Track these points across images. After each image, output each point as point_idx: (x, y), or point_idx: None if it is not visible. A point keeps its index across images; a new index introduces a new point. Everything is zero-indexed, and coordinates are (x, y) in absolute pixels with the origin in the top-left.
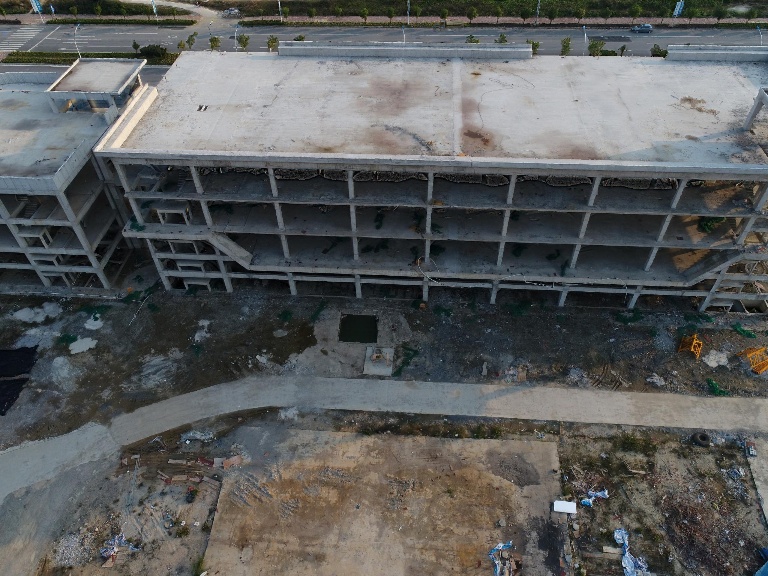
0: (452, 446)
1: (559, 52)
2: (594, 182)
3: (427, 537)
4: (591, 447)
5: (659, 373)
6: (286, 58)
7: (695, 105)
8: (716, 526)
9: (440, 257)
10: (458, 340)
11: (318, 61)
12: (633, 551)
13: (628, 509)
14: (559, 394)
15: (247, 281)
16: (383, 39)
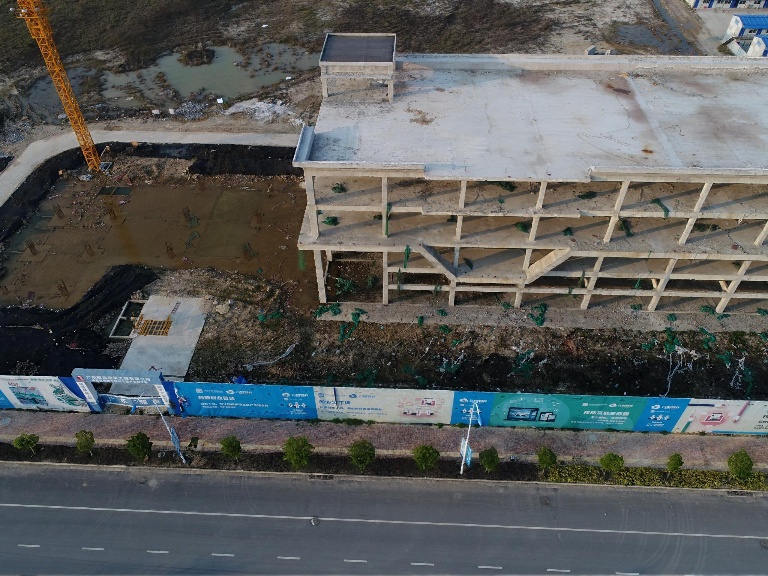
0: None
1: None
2: None
3: None
4: None
5: None
6: None
7: (422, 116)
8: None
9: None
10: None
11: None
12: None
13: None
14: None
15: None
16: None
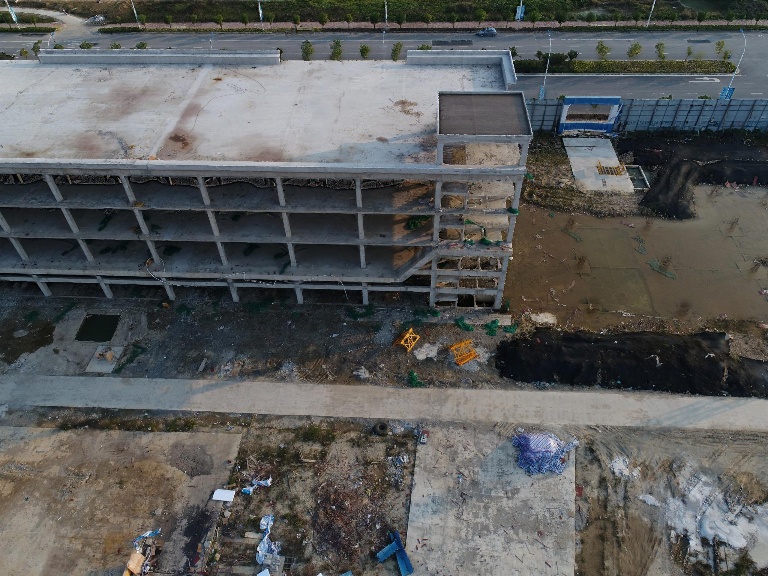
0: (142, 439)
1: (398, 56)
2: (276, 183)
3: (82, 526)
4: (273, 438)
5: (367, 366)
6: (46, 66)
7: (405, 108)
8: (361, 511)
9: (172, 257)
10: (189, 337)
11: (75, 68)
12: (273, 536)
13: (284, 496)
14: (264, 388)
15: (8, 283)
16: (233, 45)
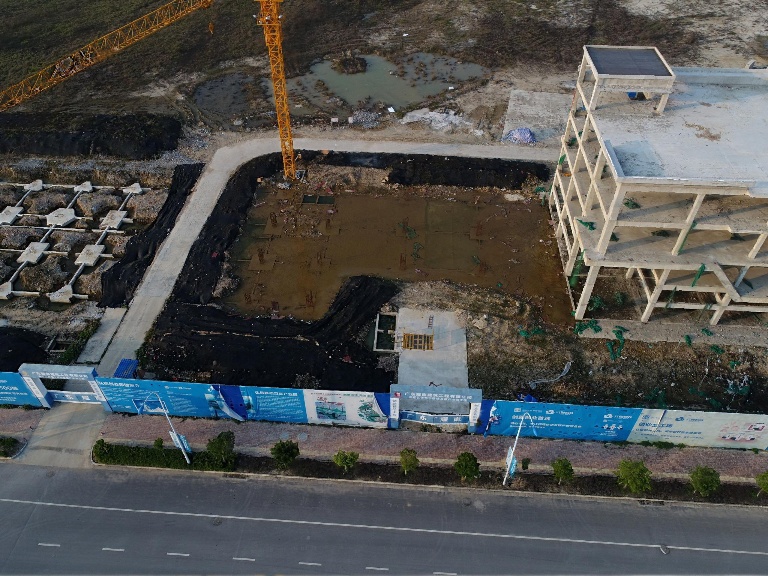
0: None
1: None
2: None
3: None
4: None
5: None
6: None
7: (706, 132)
8: None
9: None
10: None
11: None
12: None
13: None
14: None
15: None
16: None
